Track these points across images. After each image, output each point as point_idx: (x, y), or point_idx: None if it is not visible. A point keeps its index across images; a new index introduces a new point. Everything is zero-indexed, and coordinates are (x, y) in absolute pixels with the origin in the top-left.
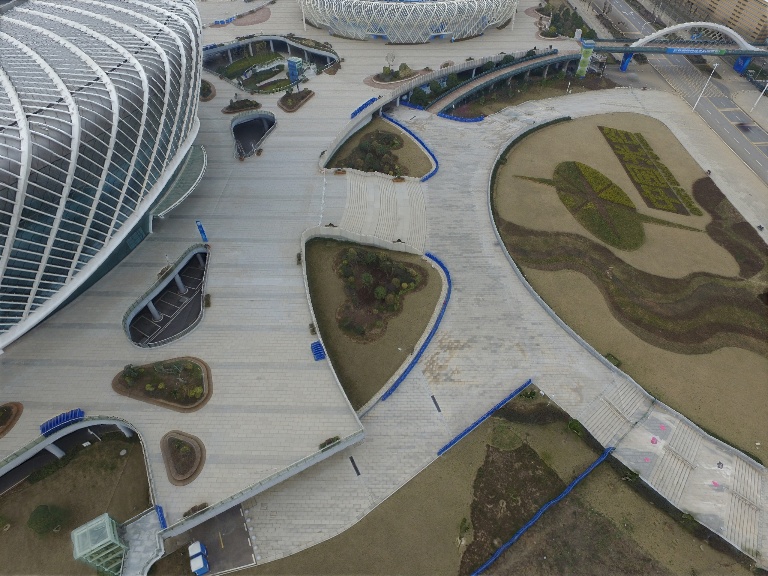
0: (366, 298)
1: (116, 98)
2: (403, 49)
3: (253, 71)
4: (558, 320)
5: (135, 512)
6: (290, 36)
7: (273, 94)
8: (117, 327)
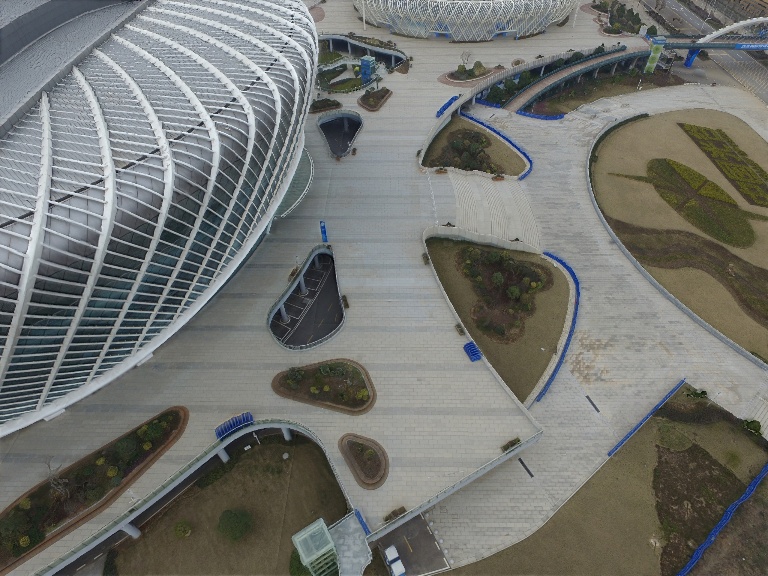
0: (498, 298)
1: (279, 98)
2: (469, 47)
3: (320, 70)
4: (696, 318)
5: (313, 516)
6: (351, 35)
7: (350, 93)
8: (260, 329)
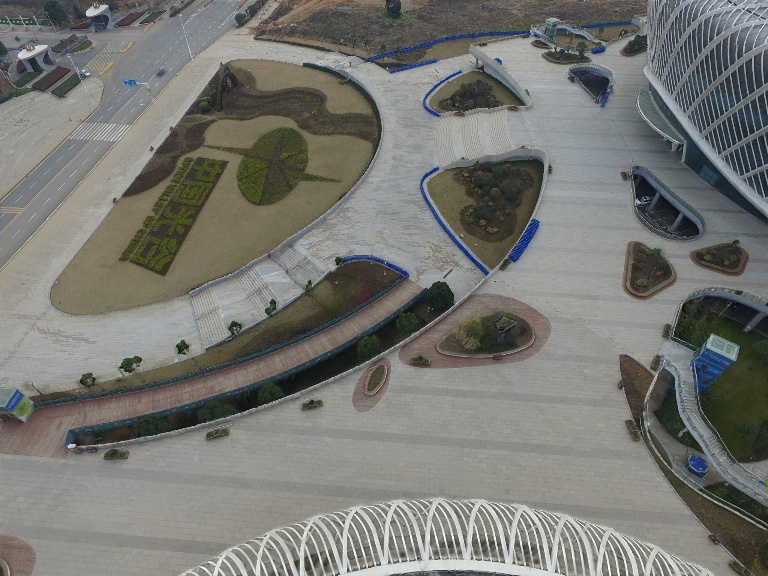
0: None
1: None
2: None
3: None
4: None
5: None
6: None
7: None
8: None
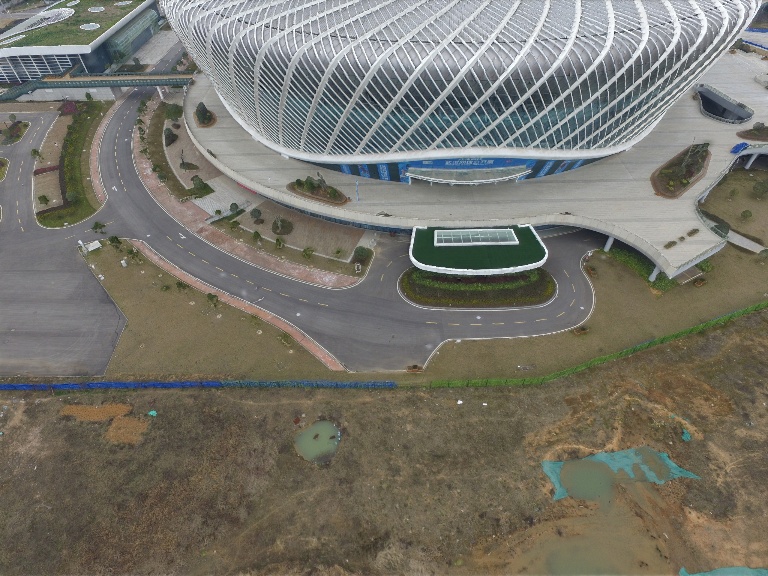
0: None
1: None
2: None
3: None
4: None
5: None
6: None
7: None
8: (703, 118)
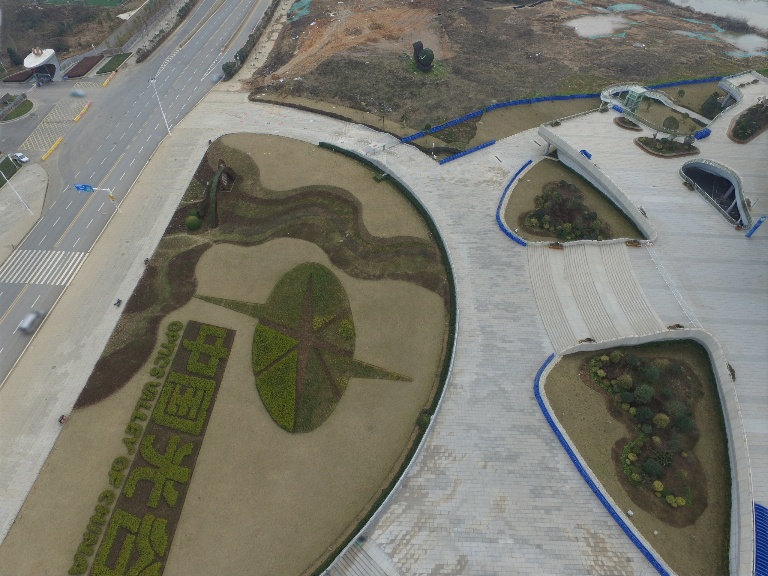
0: None
1: None
2: None
3: None
4: None
5: None
6: None
7: None
8: None
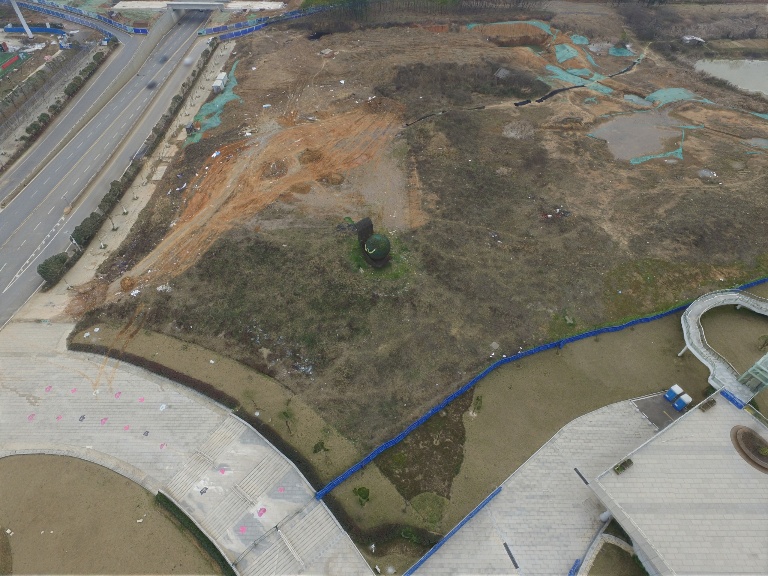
0: None
1: None
2: None
3: None
4: None
5: None
6: None
7: None
8: None
